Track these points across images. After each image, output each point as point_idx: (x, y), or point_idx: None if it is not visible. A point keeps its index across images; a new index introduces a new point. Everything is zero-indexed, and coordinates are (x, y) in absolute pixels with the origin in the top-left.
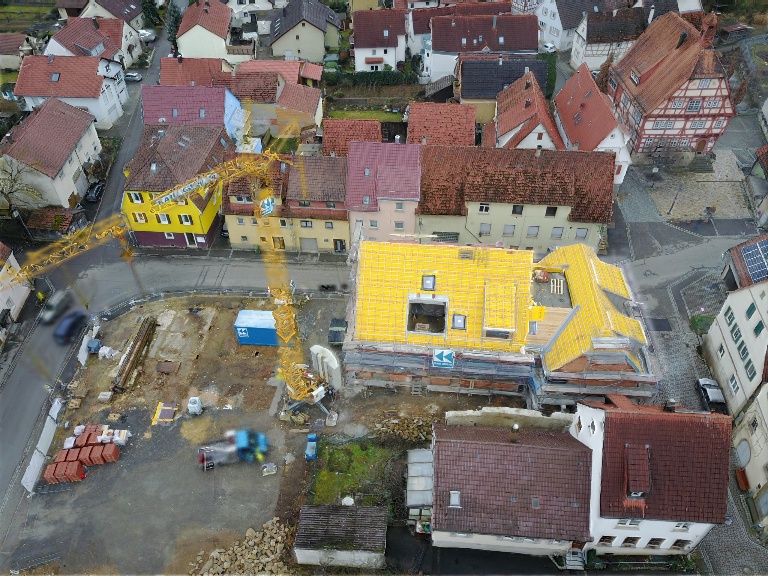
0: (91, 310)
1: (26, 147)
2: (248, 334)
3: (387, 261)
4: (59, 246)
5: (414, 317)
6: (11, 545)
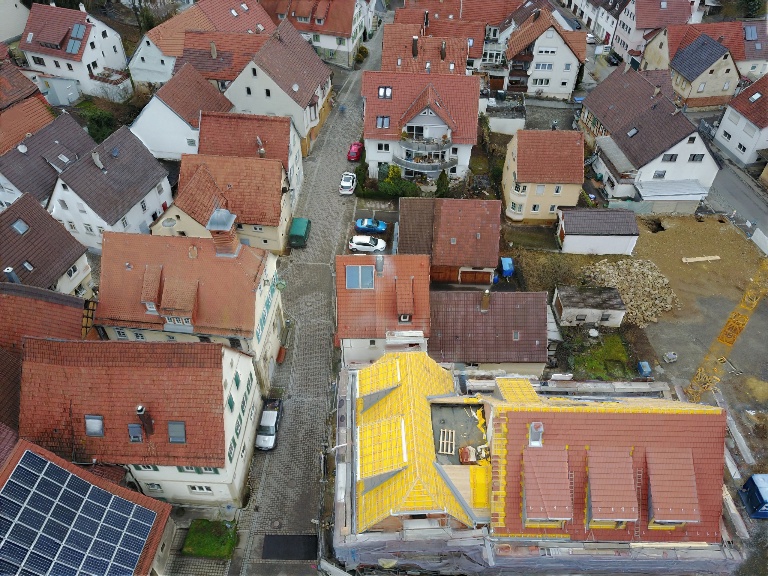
0: None
1: None
2: None
3: None
4: None
5: None
6: None
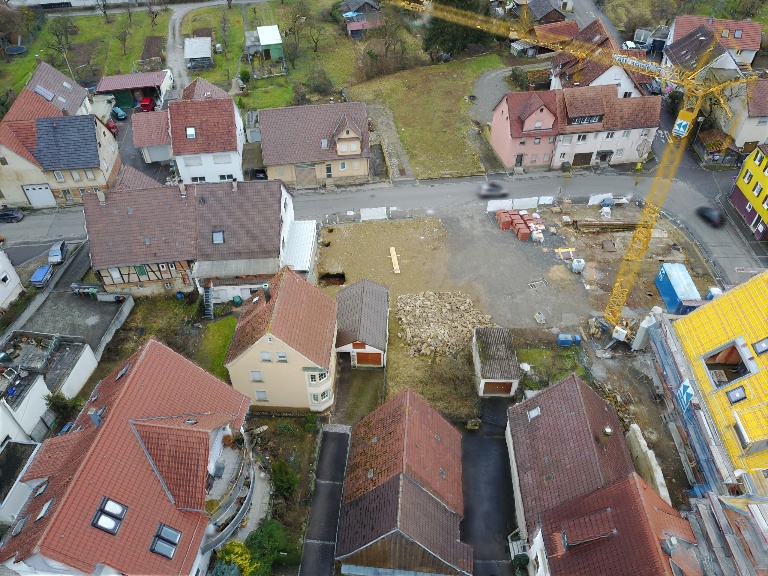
0: (642, 195)
1: (767, 87)
2: (663, 278)
3: (764, 301)
4: (697, 160)
5: (733, 370)
6: (454, 215)
